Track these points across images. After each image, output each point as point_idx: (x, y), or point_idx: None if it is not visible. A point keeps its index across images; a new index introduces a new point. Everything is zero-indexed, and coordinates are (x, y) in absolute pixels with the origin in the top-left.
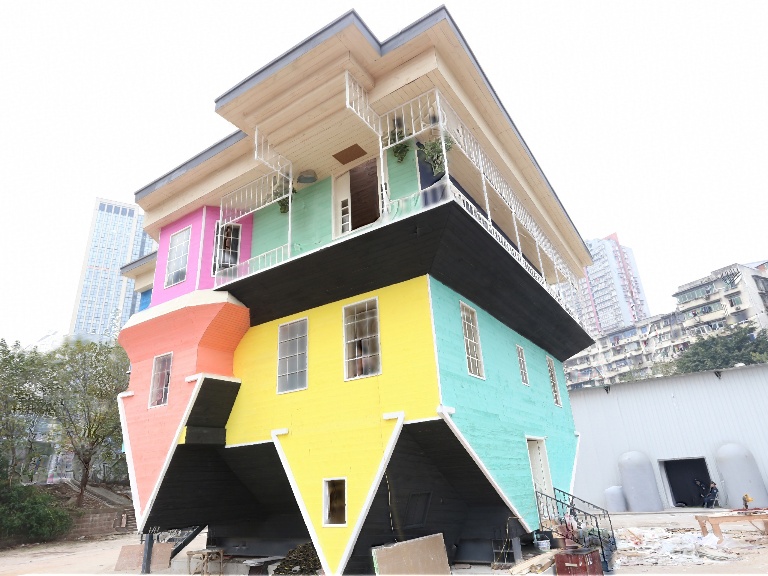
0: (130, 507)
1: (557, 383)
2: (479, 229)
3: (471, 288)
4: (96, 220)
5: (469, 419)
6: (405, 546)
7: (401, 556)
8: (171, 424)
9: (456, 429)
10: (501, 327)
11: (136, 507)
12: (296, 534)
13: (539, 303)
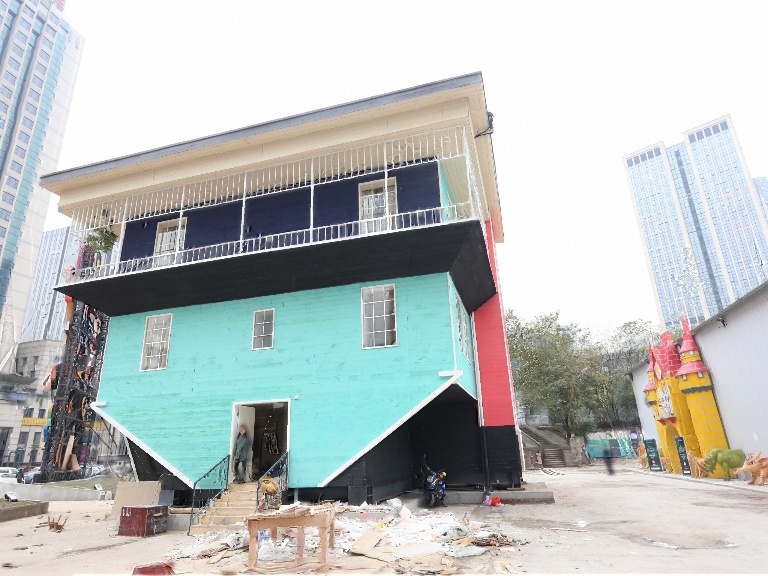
0: (559, 447)
1: (394, 314)
2: (88, 283)
3: (150, 304)
4: (630, 177)
5: (129, 405)
6: (140, 484)
7: (134, 489)
8: None
9: (102, 415)
10: (224, 307)
11: None
12: None
13: (238, 268)
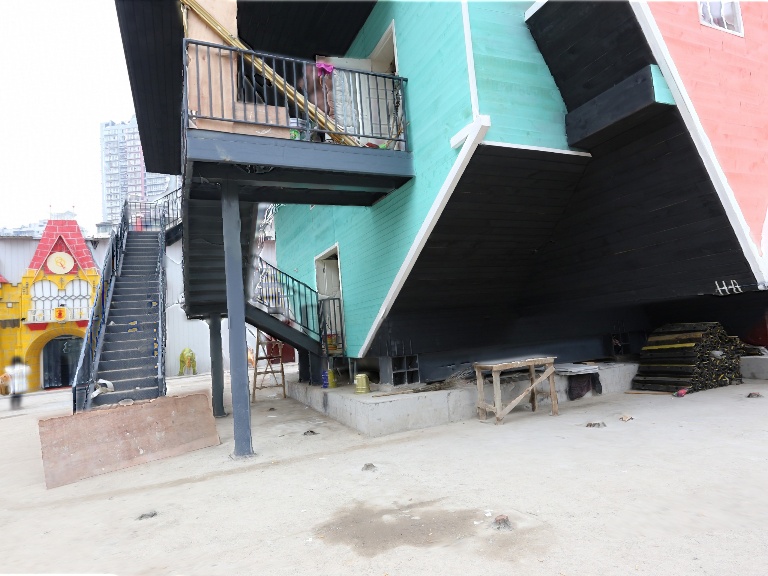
0: None
1: None
2: None
3: None
4: None
5: None
6: None
7: None
8: (766, 81)
9: None
10: None
11: (748, 233)
12: (571, 332)
13: None
